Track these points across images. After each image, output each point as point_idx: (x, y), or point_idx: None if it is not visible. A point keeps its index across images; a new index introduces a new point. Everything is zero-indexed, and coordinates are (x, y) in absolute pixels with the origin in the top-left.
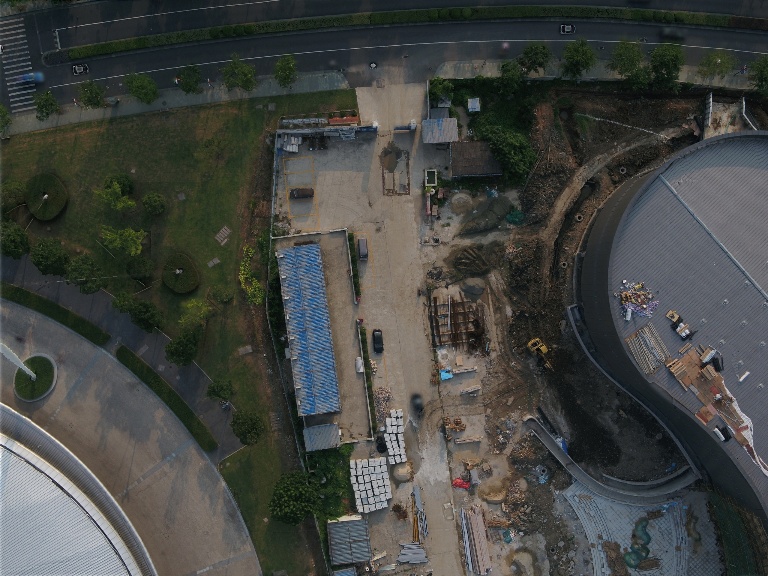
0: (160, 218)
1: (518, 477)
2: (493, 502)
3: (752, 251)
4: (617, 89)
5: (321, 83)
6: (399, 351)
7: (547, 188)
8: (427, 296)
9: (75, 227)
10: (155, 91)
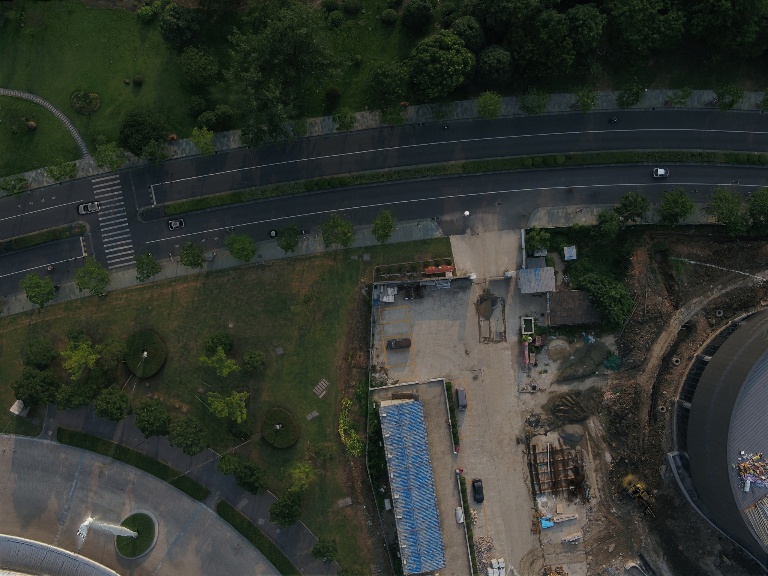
0: (259, 373)
1: None
2: None
3: None
4: (712, 232)
5: (415, 232)
6: (499, 500)
7: (645, 334)
8: (526, 444)
9: (174, 383)
10: (254, 250)
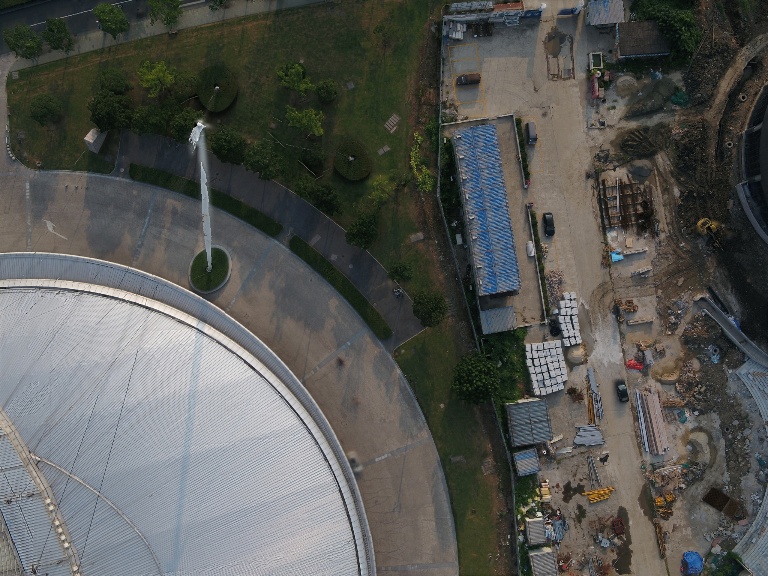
0: (330, 107)
1: (691, 357)
2: (667, 382)
3: None
4: None
5: None
6: (569, 234)
7: (712, 67)
8: (595, 179)
9: (245, 119)
10: None
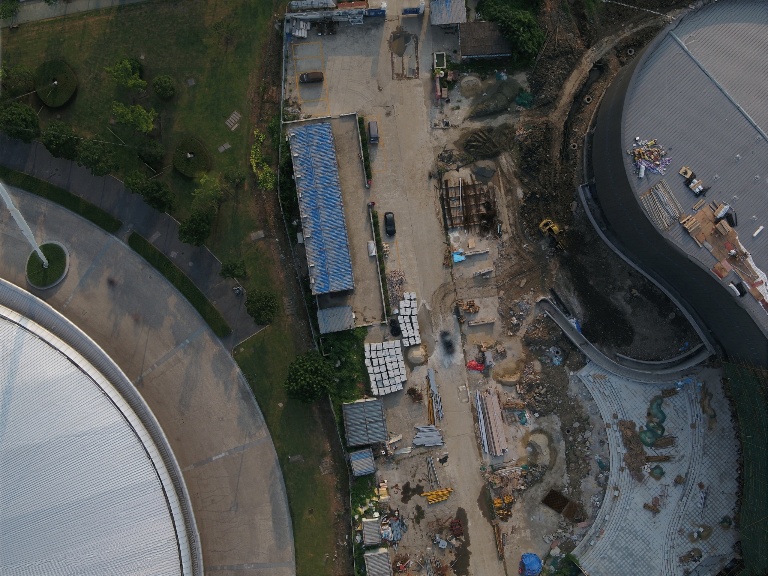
0: (170, 103)
1: (532, 359)
2: (508, 384)
3: (763, 106)
4: None
5: None
6: (411, 234)
7: (556, 69)
8: (438, 179)
9: (85, 114)
10: None
